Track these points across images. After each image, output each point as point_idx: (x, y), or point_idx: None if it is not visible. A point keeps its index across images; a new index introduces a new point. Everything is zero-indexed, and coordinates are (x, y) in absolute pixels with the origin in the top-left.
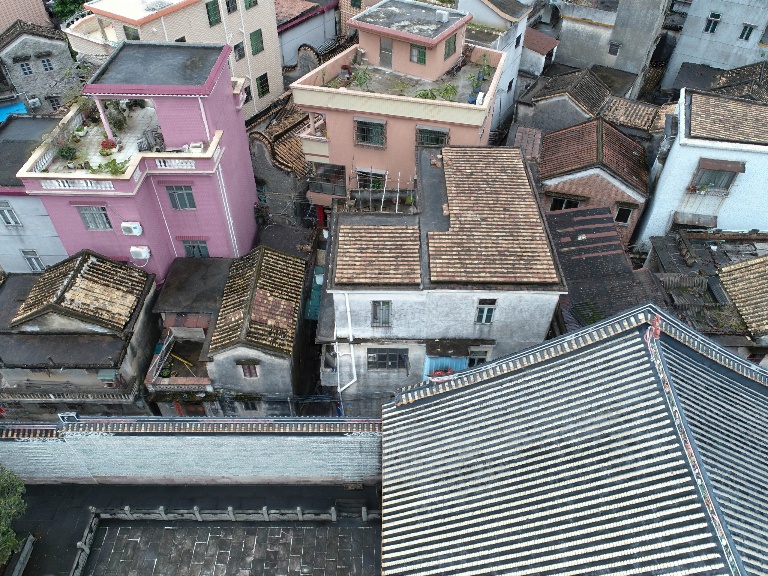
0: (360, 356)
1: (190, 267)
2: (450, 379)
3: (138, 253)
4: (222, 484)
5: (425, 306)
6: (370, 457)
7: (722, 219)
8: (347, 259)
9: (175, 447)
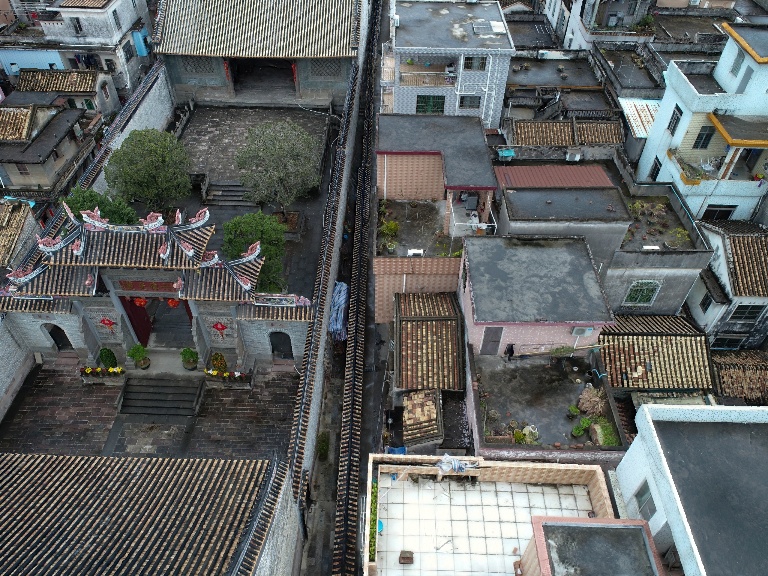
0: None
1: None
2: (159, 17)
3: None
4: None
5: (122, 6)
6: None
7: None
8: (87, 4)
9: None
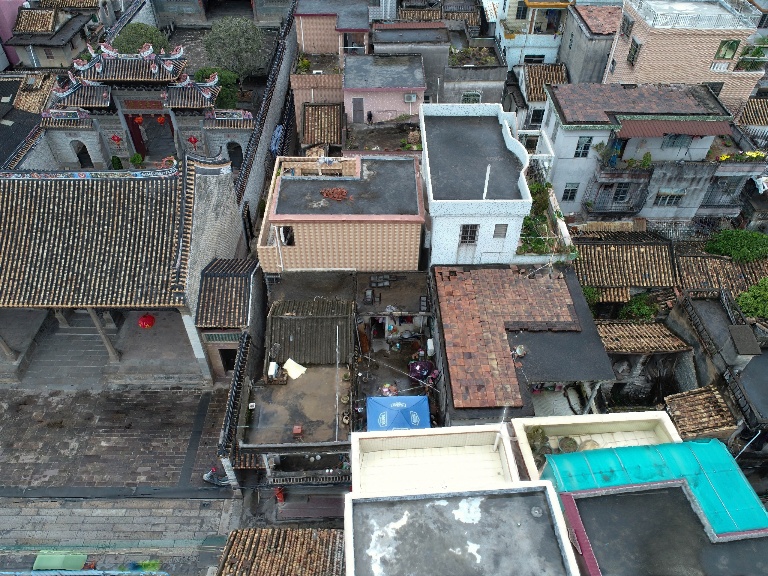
0: None
1: None
2: None
3: (27, 5)
4: None
5: None
6: (152, 15)
7: None
8: None
9: None
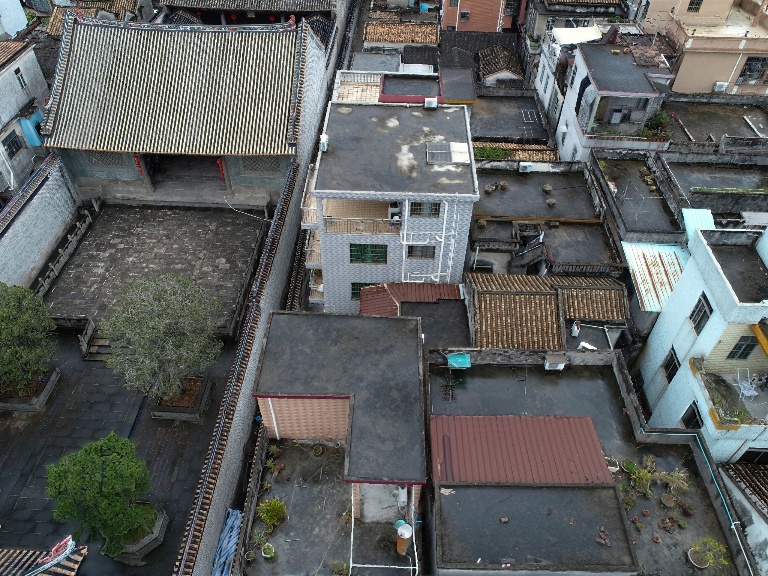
0: (2, 151)
1: None
2: None
3: None
4: (34, 279)
5: (1, 91)
6: (64, 190)
7: (9, 33)
8: None
9: (3, 256)
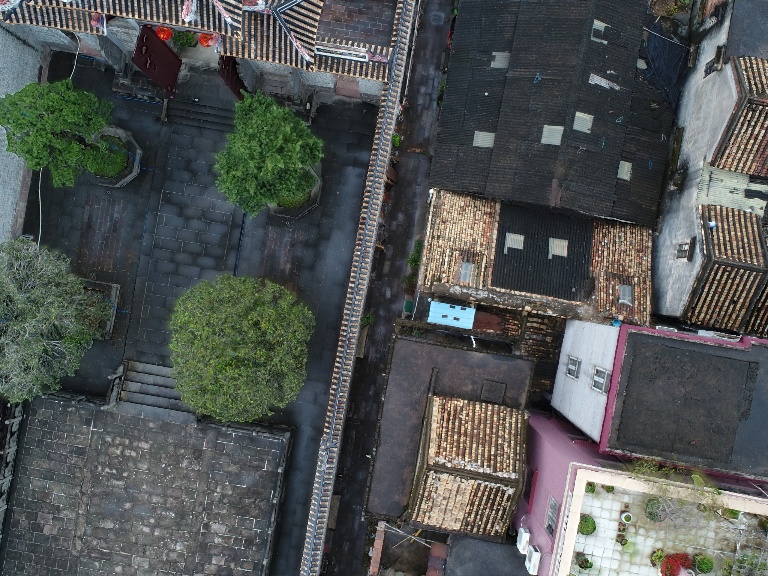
0: None
1: (524, 573)
2: None
3: None
4: None
5: None
6: None
7: None
8: None
9: None
